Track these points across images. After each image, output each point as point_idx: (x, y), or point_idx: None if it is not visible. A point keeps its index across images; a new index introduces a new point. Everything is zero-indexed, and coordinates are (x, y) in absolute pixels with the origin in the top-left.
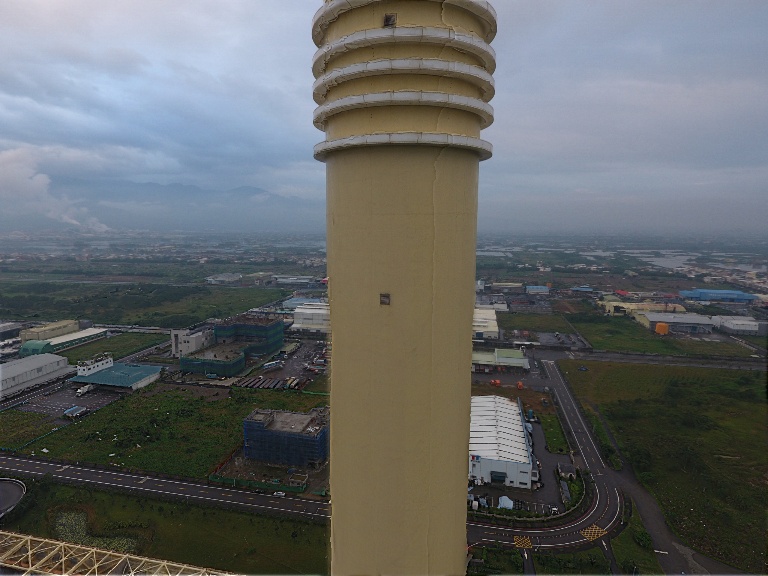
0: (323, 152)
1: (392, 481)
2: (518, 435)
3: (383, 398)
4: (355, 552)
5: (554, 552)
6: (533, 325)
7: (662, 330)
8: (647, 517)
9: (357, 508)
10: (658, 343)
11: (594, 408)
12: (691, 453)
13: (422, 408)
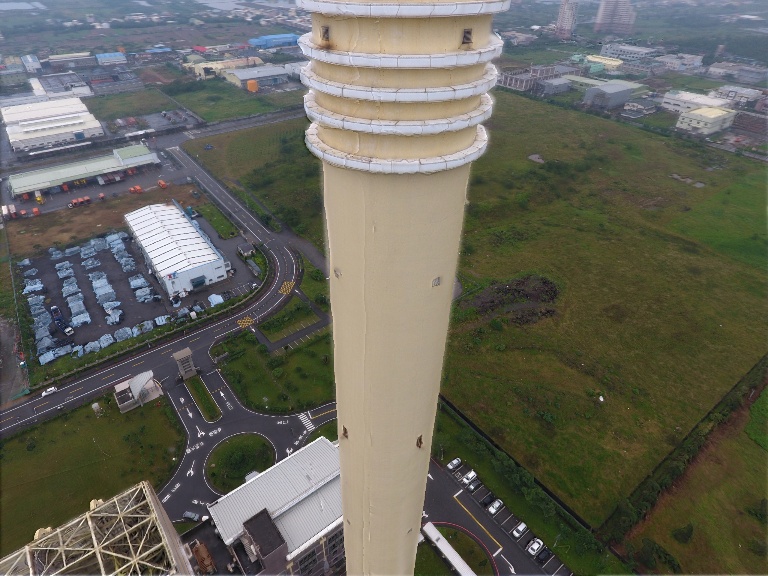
0: (381, 173)
1: (428, 386)
2: (195, 237)
3: (427, 345)
4: (399, 437)
5: (270, 316)
6: (133, 108)
7: (253, 87)
8: (313, 258)
9: (403, 415)
10: (255, 102)
11: (237, 184)
12: (321, 198)
13: (444, 335)
